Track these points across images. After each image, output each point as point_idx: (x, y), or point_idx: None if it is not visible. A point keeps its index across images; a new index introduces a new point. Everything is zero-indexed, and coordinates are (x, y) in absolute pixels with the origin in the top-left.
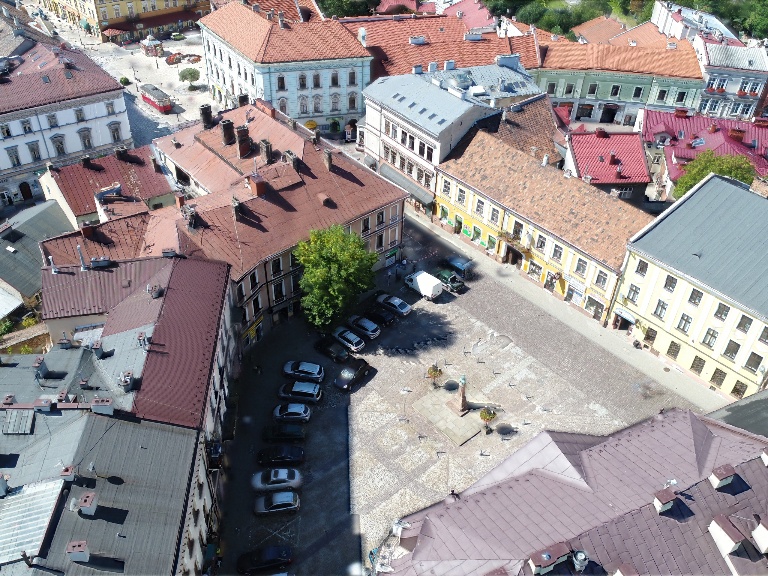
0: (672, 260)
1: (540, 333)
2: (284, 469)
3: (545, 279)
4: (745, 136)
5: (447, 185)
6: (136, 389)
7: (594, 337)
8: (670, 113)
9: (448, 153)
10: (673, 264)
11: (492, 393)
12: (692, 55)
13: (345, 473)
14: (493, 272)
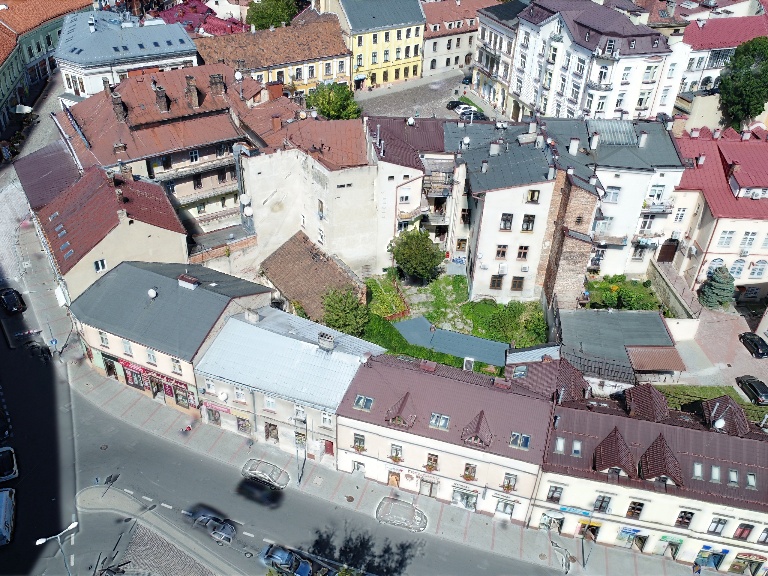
0: (371, 26)
1: None
2: None
3: None
4: None
5: None
6: None
7: (360, 99)
8: None
9: None
10: (374, 26)
11: None
12: None
13: None
14: None
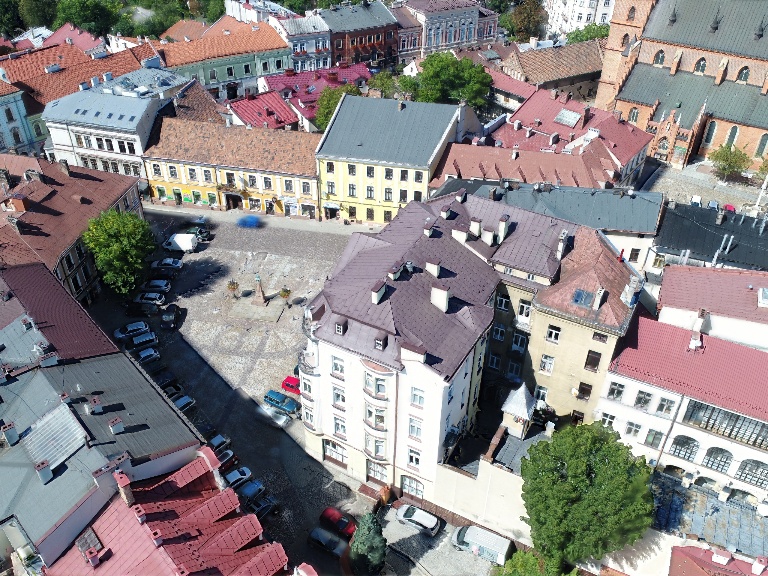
0: (347, 154)
1: (283, 241)
2: (169, 387)
3: (265, 207)
4: (338, 77)
5: (157, 168)
6: (54, 351)
7: (318, 229)
8: (282, 75)
9: (146, 143)
10: (349, 156)
11: (276, 286)
12: (273, 32)
13: (212, 372)
14: (224, 219)
